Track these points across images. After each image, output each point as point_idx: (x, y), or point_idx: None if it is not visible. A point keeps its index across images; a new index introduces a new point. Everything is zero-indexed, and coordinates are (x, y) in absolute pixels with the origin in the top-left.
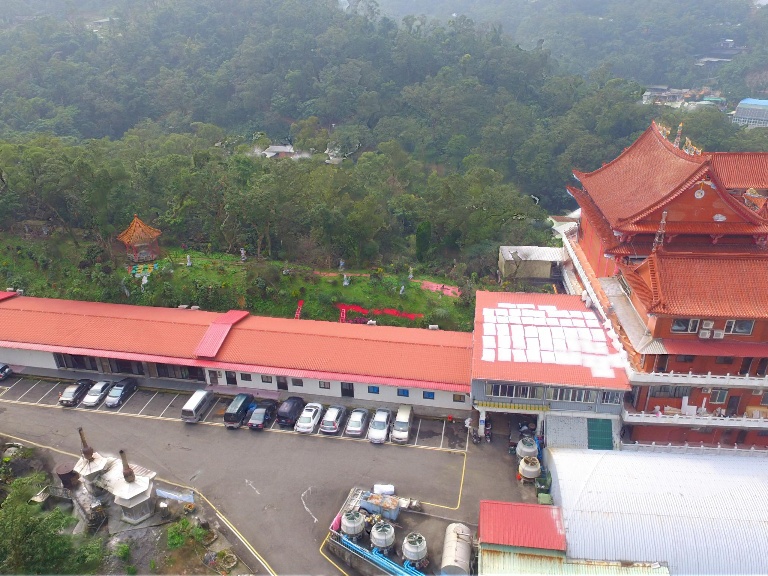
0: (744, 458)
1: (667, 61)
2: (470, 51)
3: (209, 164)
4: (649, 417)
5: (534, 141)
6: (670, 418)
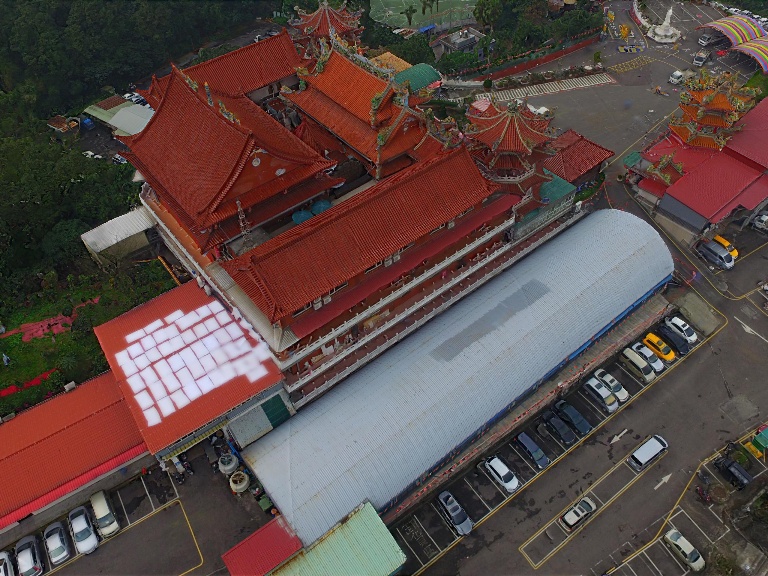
0: (378, 371)
1: None
2: None
3: None
4: (305, 379)
5: (25, 20)
6: (319, 369)
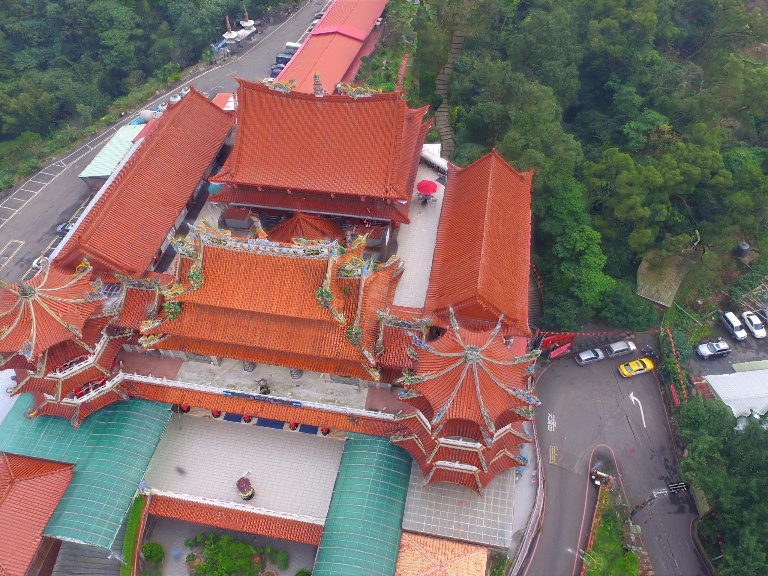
0: None
1: None
2: None
3: None
4: None
5: None
6: None
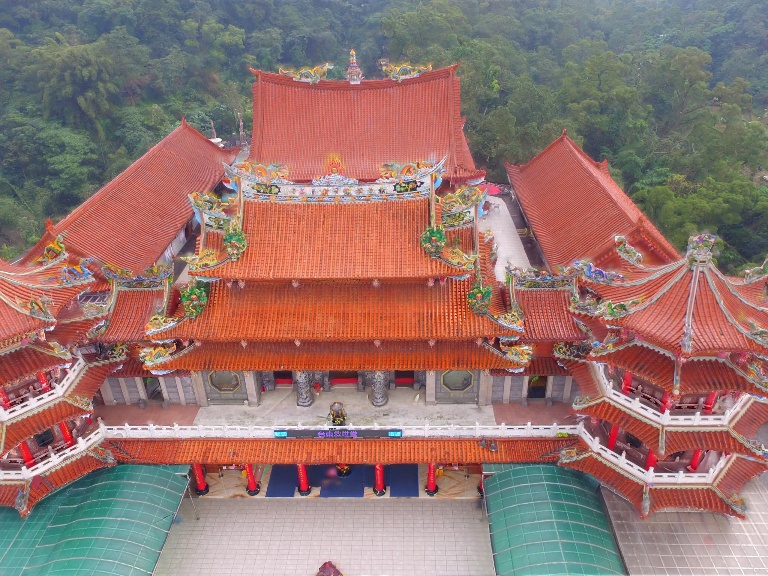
0: None
1: None
2: None
3: (452, 47)
4: None
5: None
6: None
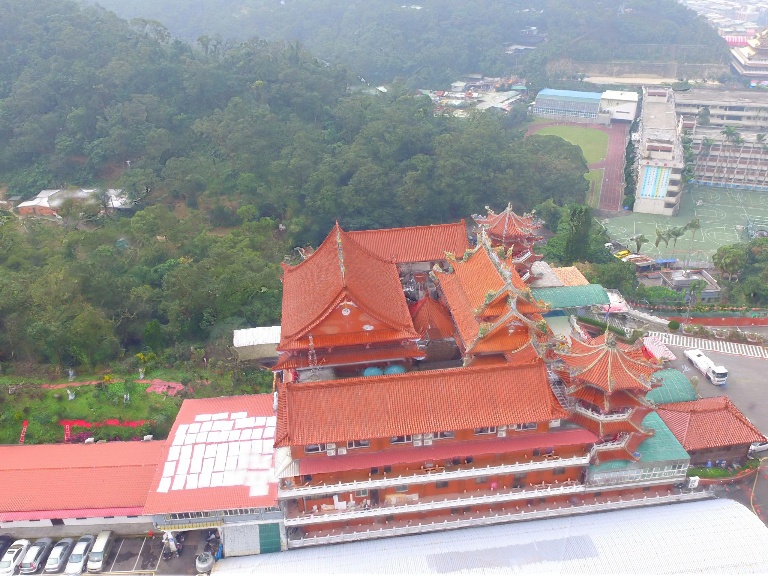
0: (372, 548)
1: (479, 51)
2: (265, 74)
3: None
4: (304, 520)
5: (319, 174)
6: (321, 518)
